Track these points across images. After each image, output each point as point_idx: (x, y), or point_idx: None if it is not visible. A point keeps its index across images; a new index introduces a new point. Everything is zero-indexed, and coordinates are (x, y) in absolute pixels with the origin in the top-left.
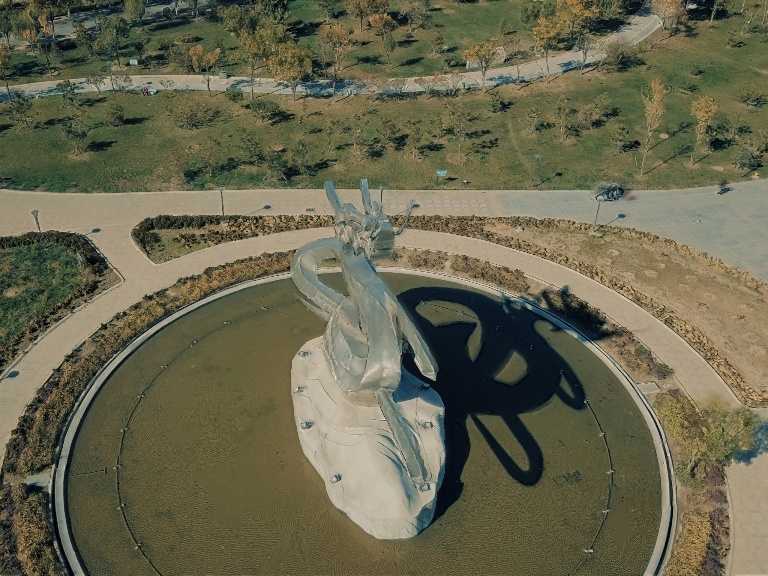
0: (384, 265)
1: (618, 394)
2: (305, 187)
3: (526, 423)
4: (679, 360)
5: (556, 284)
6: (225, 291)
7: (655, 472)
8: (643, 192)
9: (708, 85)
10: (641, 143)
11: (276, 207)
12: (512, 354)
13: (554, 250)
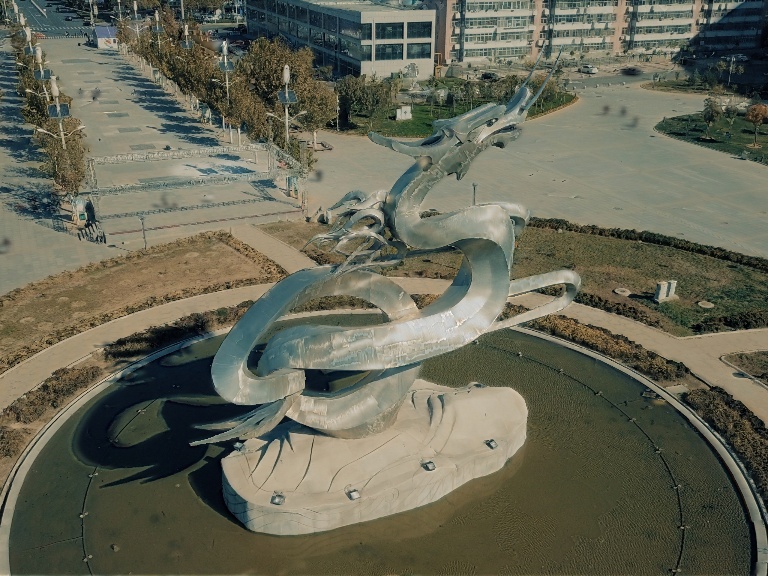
0: (2, 482)
1: (284, 326)
2: None
3: None
4: (231, 299)
5: (91, 351)
6: None
7: (379, 316)
8: None
9: None
10: None
11: None
12: None
13: (9, 353)
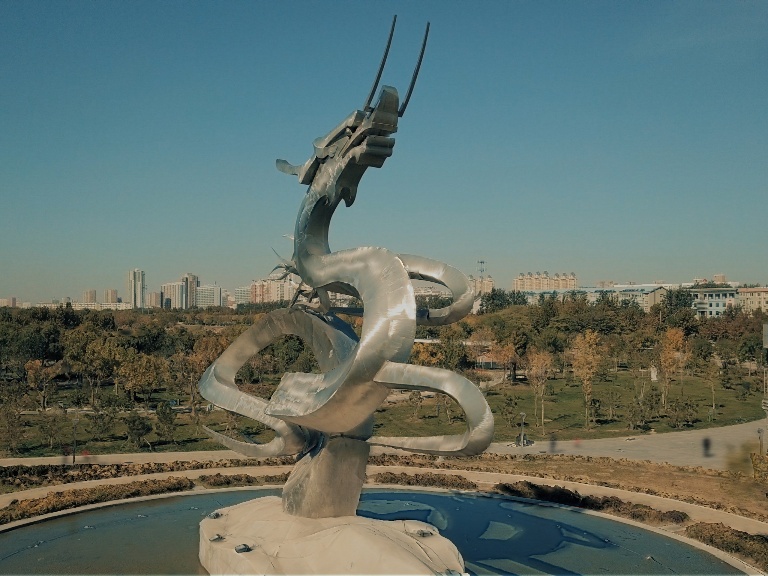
0: None
1: (640, 534)
2: (174, 451)
3: (545, 561)
4: (686, 511)
5: (506, 482)
6: (82, 507)
7: None
8: (553, 442)
9: (566, 399)
10: (529, 423)
11: (140, 462)
12: (489, 522)
13: None
